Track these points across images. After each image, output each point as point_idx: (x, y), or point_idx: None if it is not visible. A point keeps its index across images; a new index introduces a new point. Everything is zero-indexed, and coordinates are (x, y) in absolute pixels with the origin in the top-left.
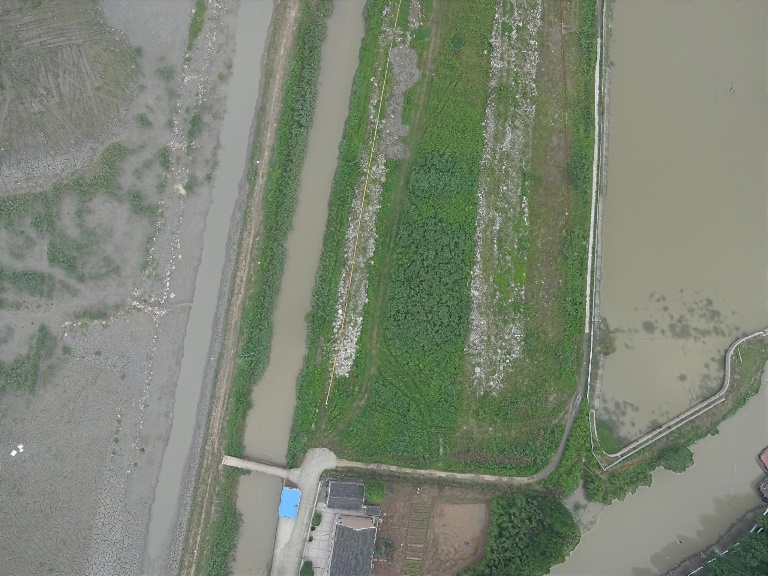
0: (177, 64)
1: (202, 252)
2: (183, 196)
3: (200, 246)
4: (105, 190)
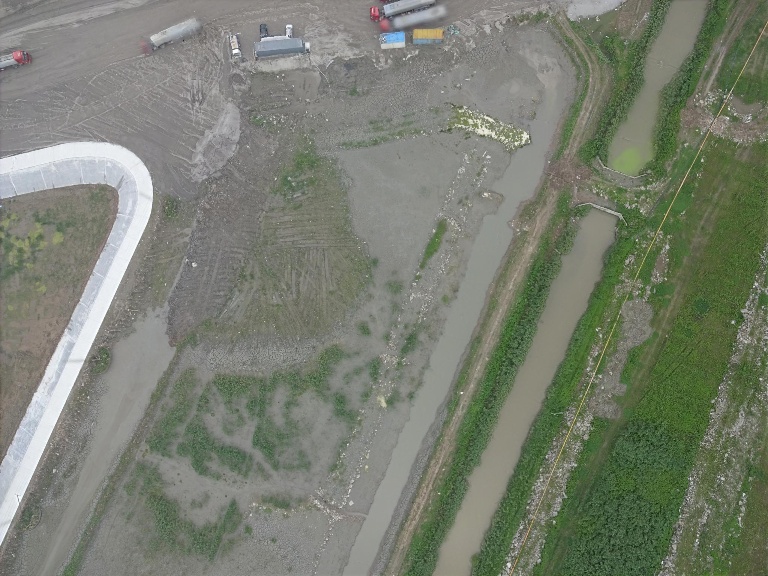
0: (407, 280)
1: (388, 467)
2: (383, 409)
3: (387, 461)
4: (315, 389)
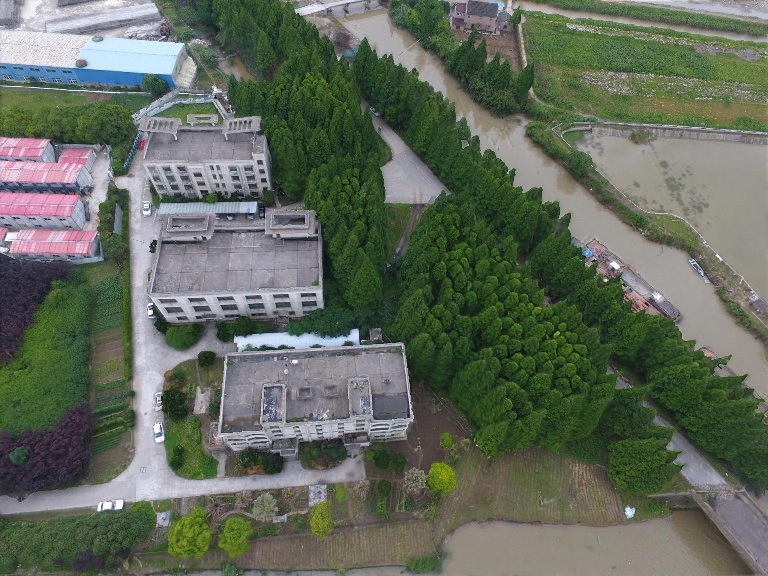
0: None
1: None
2: None
3: None
4: None
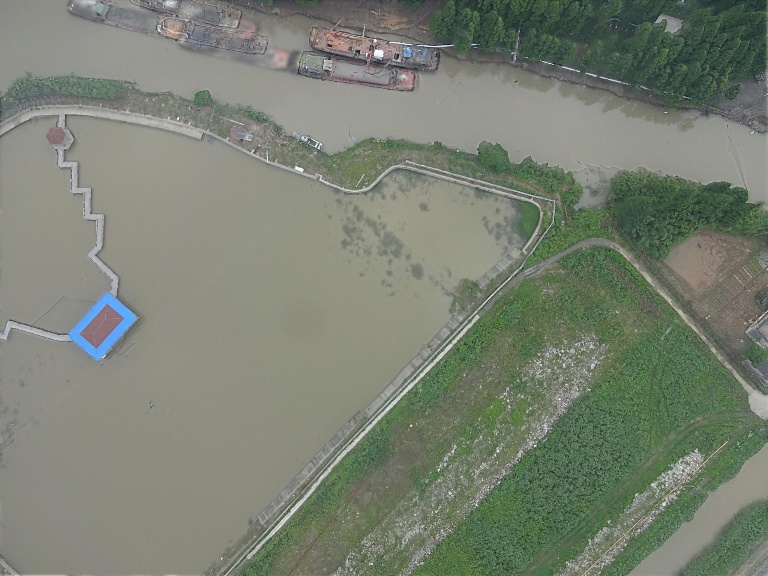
0: None
1: None
2: None
3: None
4: None
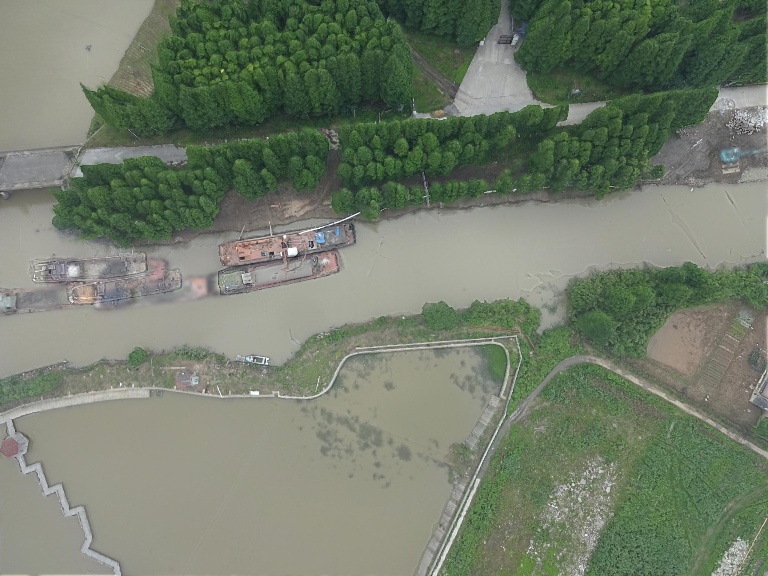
0: None
1: None
2: None
3: None
4: None
